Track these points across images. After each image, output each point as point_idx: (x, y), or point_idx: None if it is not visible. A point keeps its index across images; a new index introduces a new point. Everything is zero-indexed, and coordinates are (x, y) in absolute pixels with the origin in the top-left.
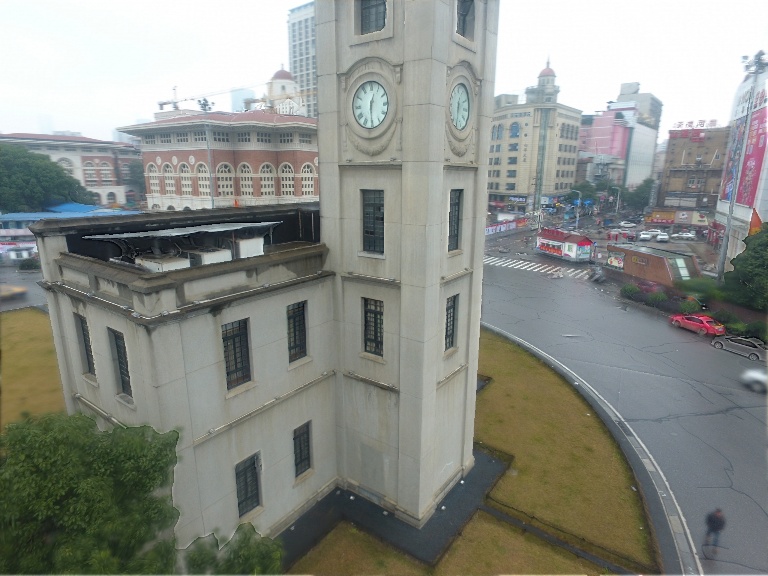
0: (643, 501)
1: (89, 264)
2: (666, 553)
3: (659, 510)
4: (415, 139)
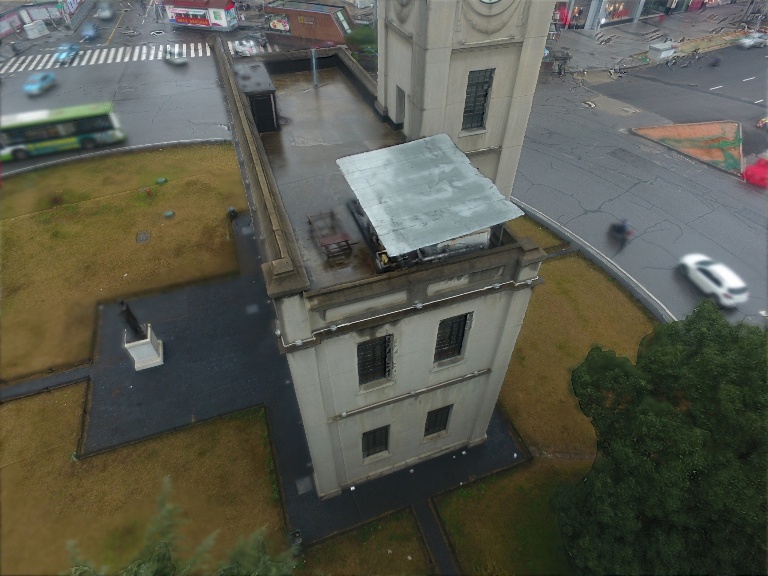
0: (528, 215)
1: (401, 279)
2: (558, 233)
3: (533, 215)
4: (541, 15)
